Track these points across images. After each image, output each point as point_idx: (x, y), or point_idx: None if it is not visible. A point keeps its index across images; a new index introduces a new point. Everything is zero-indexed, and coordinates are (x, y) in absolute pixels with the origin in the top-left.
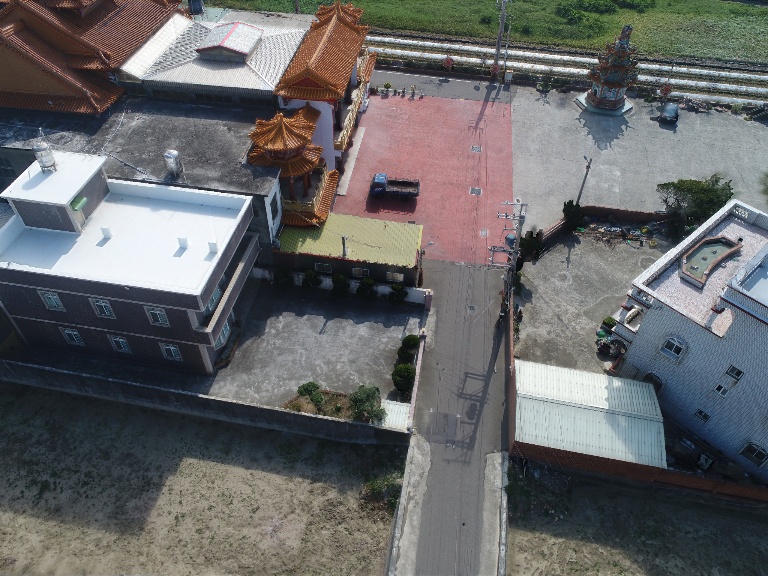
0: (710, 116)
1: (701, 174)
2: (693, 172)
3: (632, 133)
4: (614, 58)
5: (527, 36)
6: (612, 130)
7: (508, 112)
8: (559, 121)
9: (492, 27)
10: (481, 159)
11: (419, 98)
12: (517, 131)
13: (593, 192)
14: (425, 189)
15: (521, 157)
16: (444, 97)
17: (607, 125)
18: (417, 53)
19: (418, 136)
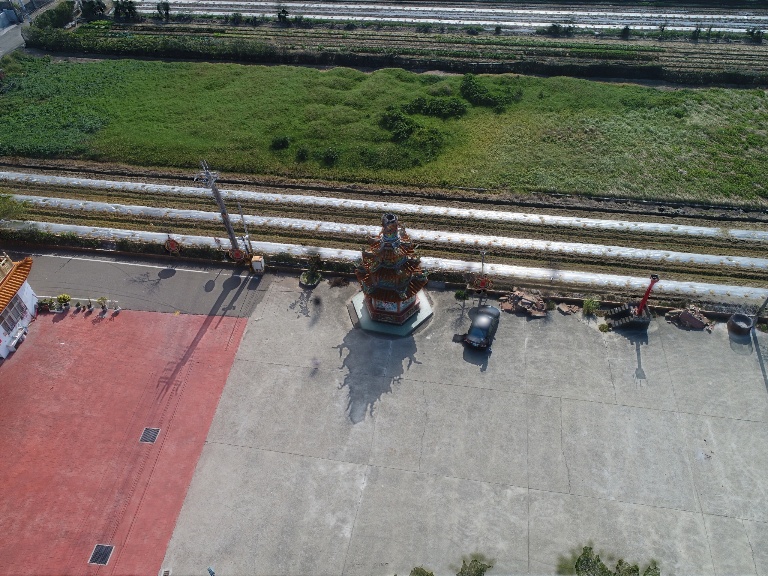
0: (548, 325)
1: (502, 476)
2: (489, 472)
3: (415, 376)
4: (380, 259)
5: (329, 167)
6: (385, 371)
7: (236, 338)
8: (308, 354)
9: (285, 154)
10: (147, 462)
11: (111, 316)
12: (233, 384)
13: (304, 542)
14: (14, 556)
15: (215, 451)
16: (151, 311)
17: (381, 359)
18: (162, 210)
19: (67, 410)
